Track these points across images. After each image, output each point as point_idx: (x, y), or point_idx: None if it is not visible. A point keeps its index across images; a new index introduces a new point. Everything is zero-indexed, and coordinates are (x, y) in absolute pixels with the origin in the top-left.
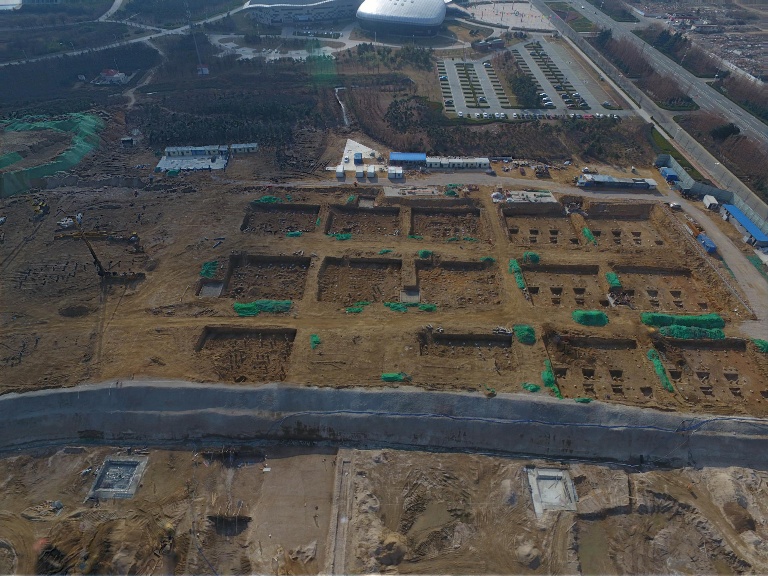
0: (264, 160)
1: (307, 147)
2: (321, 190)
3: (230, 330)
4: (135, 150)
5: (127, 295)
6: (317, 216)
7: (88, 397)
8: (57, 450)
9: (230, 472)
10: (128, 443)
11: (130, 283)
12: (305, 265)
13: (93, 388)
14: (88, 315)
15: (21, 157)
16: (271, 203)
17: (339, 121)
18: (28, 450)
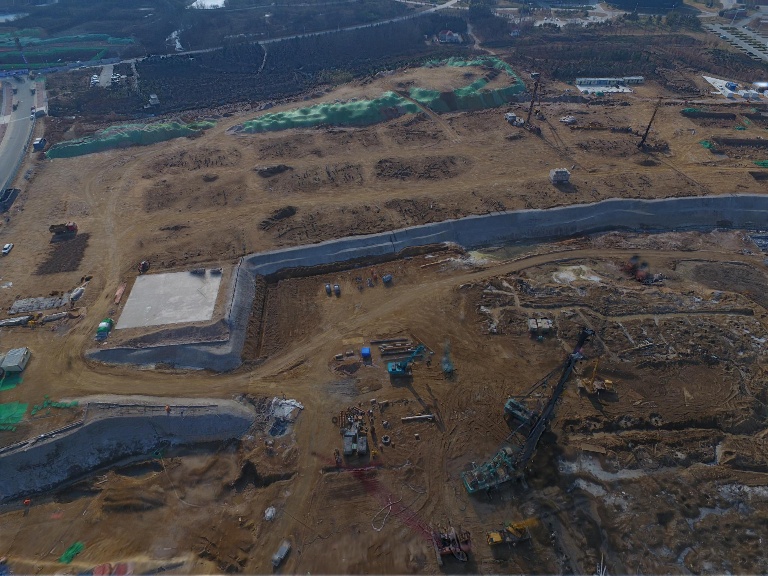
0: (656, 87)
1: (678, 80)
2: (725, 105)
3: (765, 174)
4: (548, 81)
5: (670, 157)
6: (737, 121)
7: (718, 201)
8: (711, 230)
9: None
10: (750, 229)
11: (662, 151)
12: (766, 146)
13: (719, 197)
14: (659, 166)
15: (486, 82)
16: (697, 112)
17: (673, 66)
18: (694, 229)
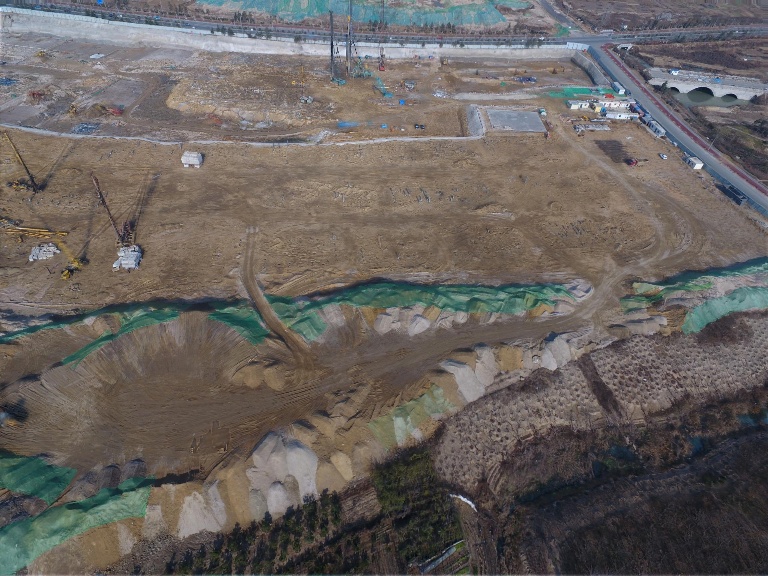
0: None
1: None
2: None
3: None
4: None
5: None
6: None
7: None
8: None
9: (37, 126)
10: None
11: None
12: None
13: (75, 135)
14: None
15: (63, 361)
16: None
17: None
18: None
